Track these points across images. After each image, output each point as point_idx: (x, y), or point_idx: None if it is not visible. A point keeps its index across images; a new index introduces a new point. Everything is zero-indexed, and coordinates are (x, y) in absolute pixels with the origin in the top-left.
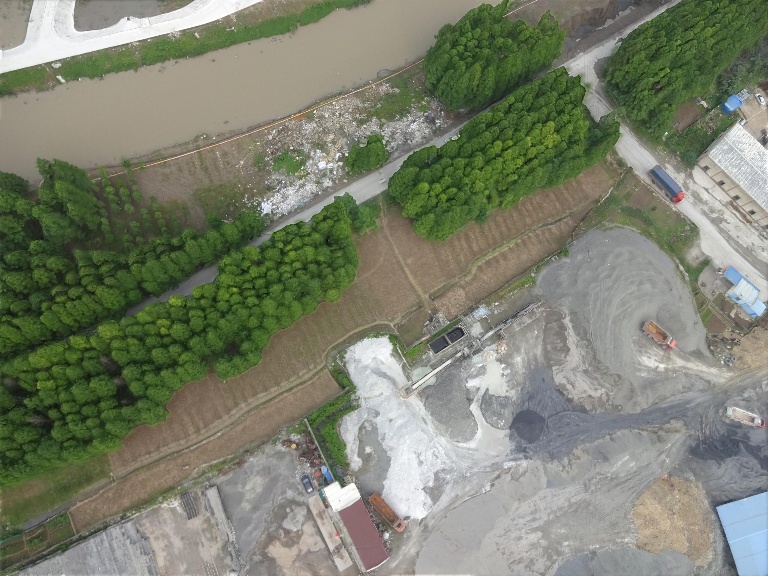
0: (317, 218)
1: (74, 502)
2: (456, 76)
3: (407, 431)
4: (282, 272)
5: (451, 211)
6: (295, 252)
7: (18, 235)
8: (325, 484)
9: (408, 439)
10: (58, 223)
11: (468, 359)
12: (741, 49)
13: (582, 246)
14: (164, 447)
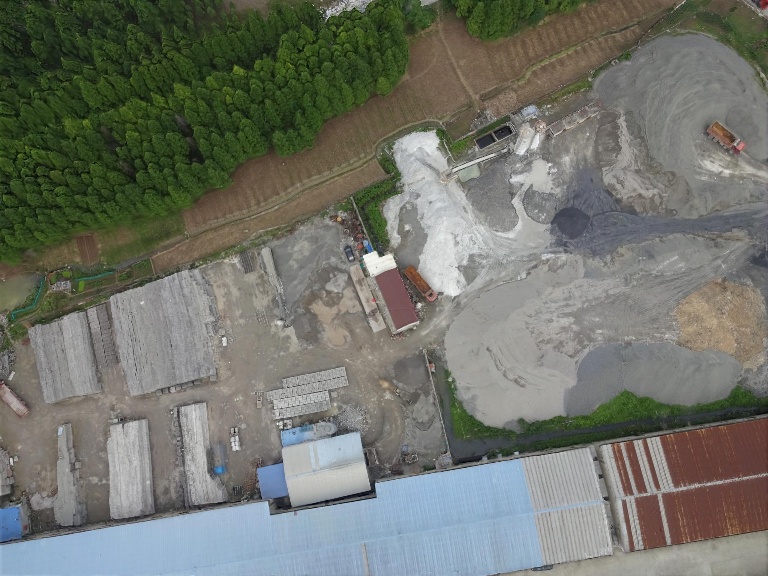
0: (369, 6)
1: (156, 252)
2: None
3: (446, 214)
4: (333, 51)
5: (501, 0)
6: (346, 33)
7: (119, 22)
8: None
9: (446, 220)
10: (149, 9)
11: (513, 155)
12: None
13: (646, 50)
14: (229, 214)
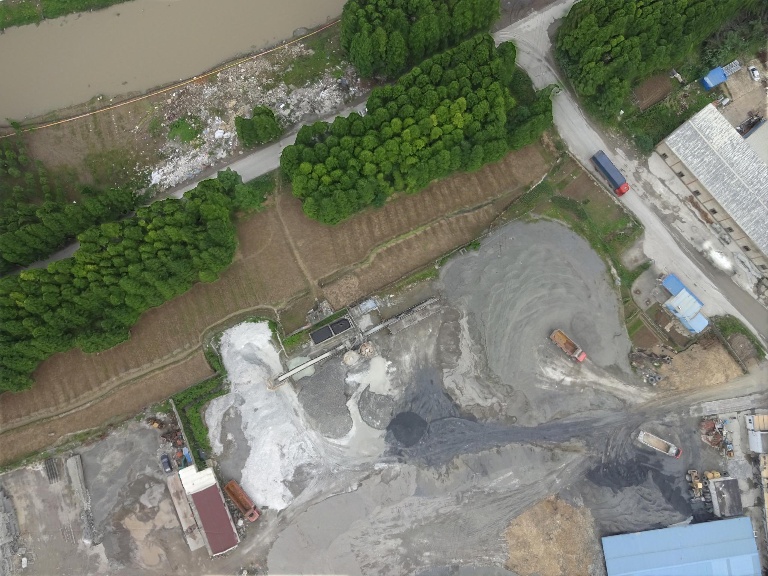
0: (185, 196)
1: None
2: (360, 41)
3: (272, 422)
4: (141, 252)
5: (333, 196)
6: (155, 232)
7: None
8: (185, 465)
9: (272, 430)
10: None
11: None
12: (740, 10)
13: (496, 239)
14: (34, 412)
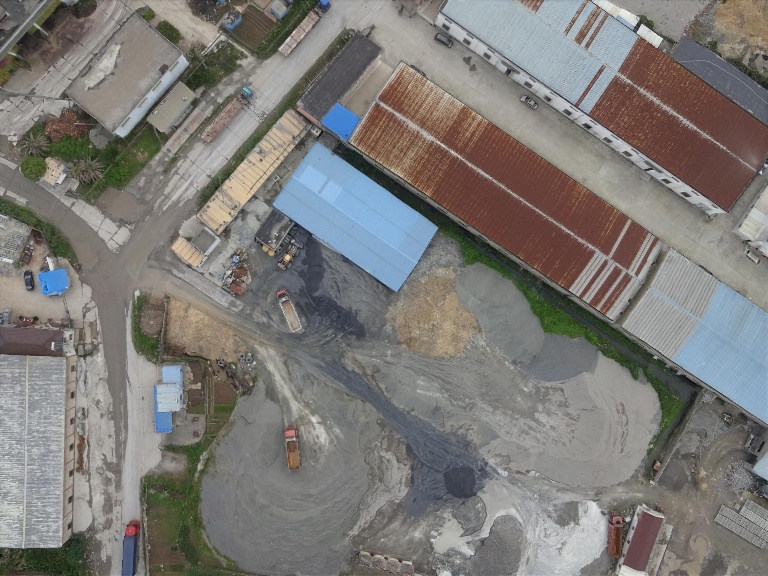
0: None
1: None
2: None
3: (551, 574)
4: None
5: None
6: None
7: None
8: None
9: (556, 569)
10: None
11: None
12: None
13: (271, 571)
14: None
